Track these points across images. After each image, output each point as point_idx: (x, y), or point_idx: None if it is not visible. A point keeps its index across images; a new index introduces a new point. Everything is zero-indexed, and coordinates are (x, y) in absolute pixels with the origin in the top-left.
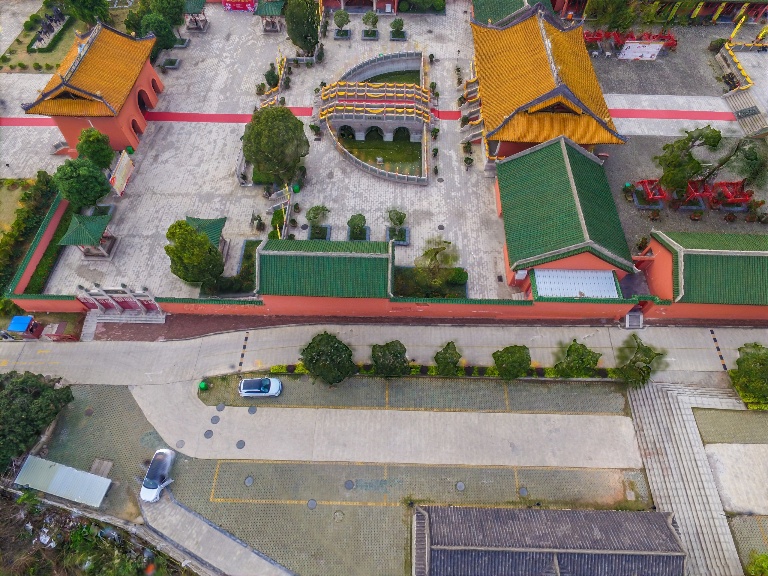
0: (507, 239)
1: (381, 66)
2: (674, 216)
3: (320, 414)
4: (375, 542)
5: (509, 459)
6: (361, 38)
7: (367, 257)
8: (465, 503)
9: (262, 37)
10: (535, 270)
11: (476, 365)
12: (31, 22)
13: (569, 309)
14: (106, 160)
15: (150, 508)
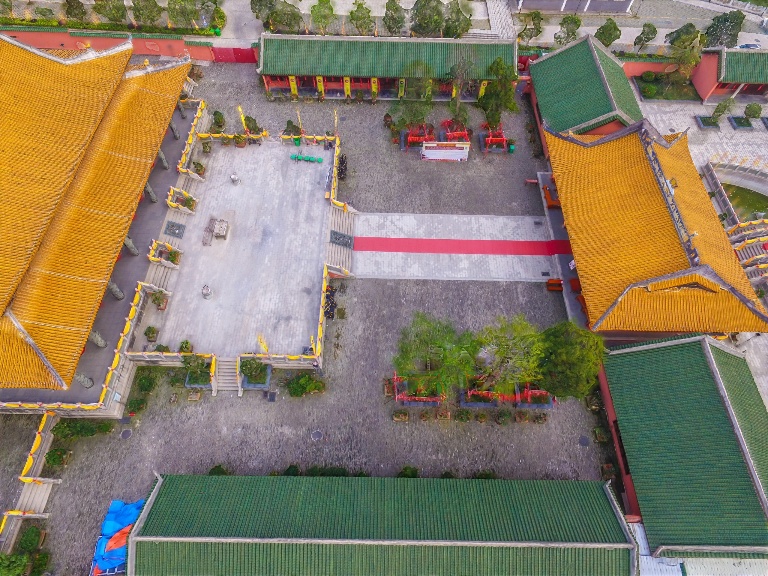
0: None
1: None
2: None
3: None
4: (647, 8)
5: (587, 29)
6: None
7: None
8: (607, 17)
9: None
10: None
11: None
12: None
13: None
14: None
15: None
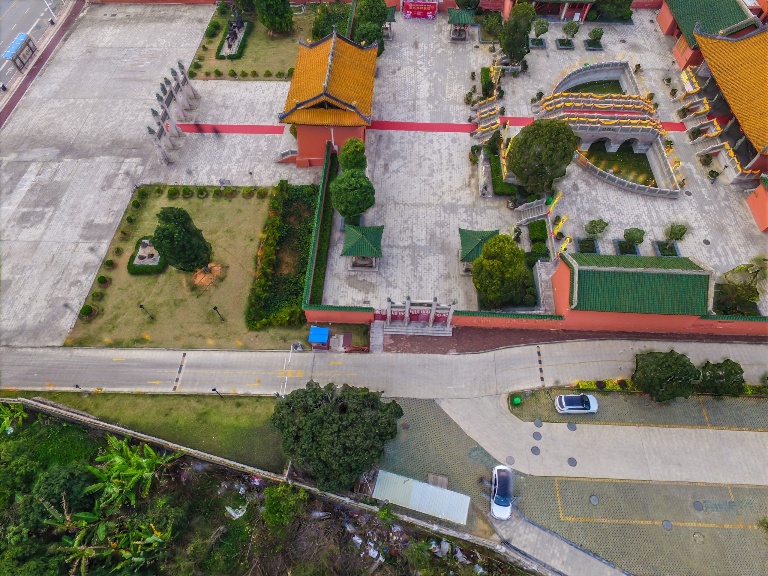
0: None
1: (584, 76)
2: None
3: (643, 432)
4: (745, 566)
5: None
6: (556, 47)
7: (687, 274)
8: None
9: (450, 45)
10: None
11: None
12: (213, 28)
13: None
14: (362, 170)
15: (502, 526)
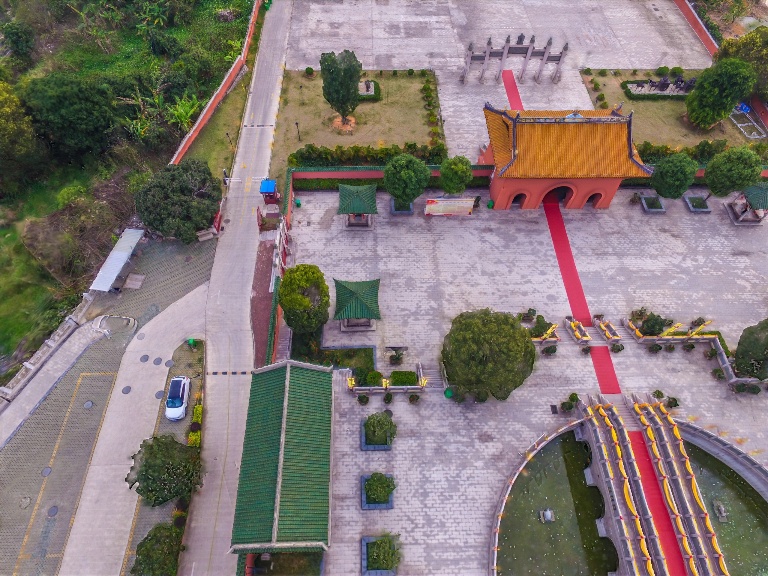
0: None
1: None
2: None
3: None
4: None
5: None
6: None
7: None
8: None
9: (765, 296)
10: None
11: None
12: (667, 70)
13: None
14: (447, 188)
15: None
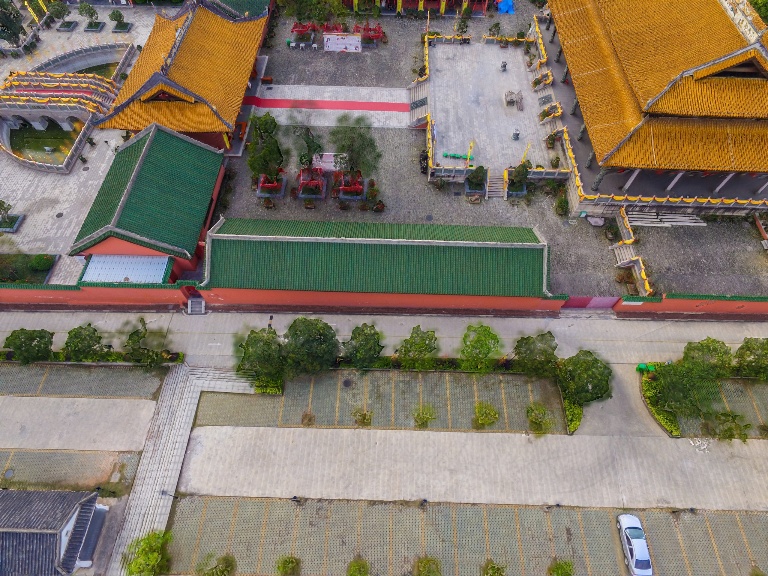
0: (82, 225)
1: (93, 57)
2: (291, 204)
3: None
4: None
5: (12, 442)
6: (85, 30)
7: None
8: None
9: None
10: (93, 256)
11: None
12: None
13: (125, 294)
14: None
15: None
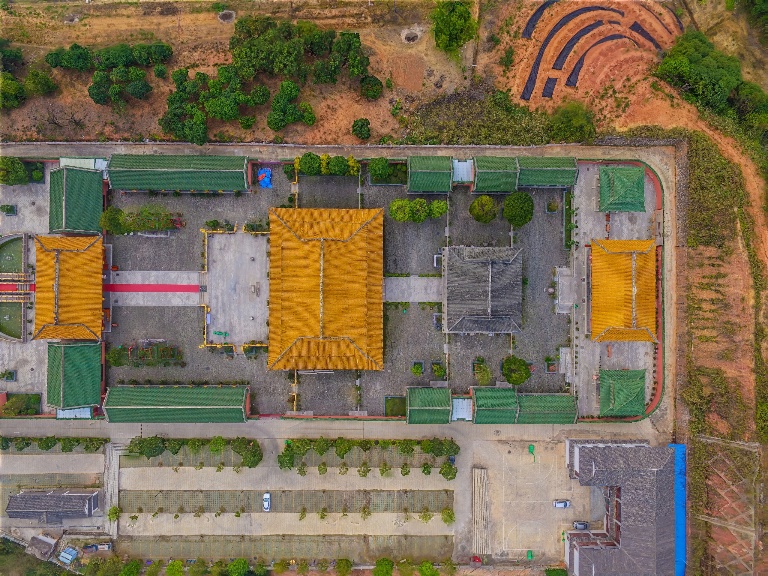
0: (47, 390)
1: (2, 240)
2: (141, 363)
3: None
4: (7, 499)
5: (56, 471)
6: None
7: None
8: (39, 486)
9: None
10: None
11: (46, 436)
12: None
13: None
14: None
15: None
